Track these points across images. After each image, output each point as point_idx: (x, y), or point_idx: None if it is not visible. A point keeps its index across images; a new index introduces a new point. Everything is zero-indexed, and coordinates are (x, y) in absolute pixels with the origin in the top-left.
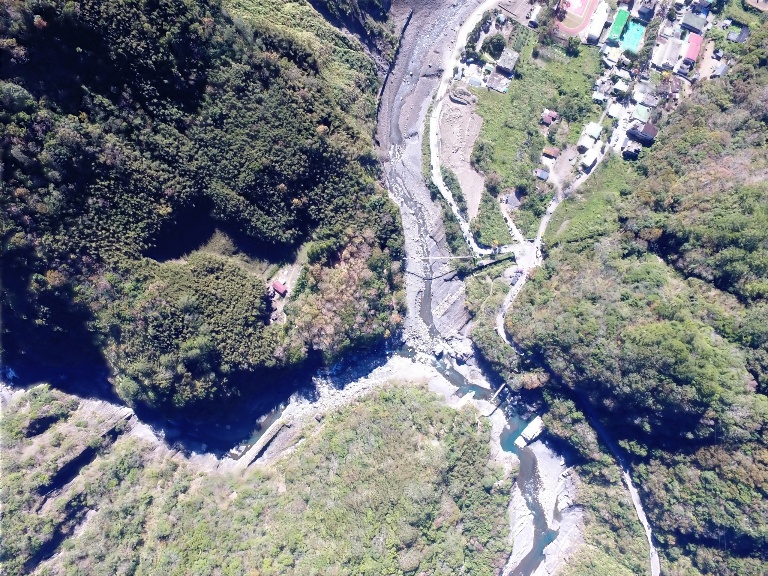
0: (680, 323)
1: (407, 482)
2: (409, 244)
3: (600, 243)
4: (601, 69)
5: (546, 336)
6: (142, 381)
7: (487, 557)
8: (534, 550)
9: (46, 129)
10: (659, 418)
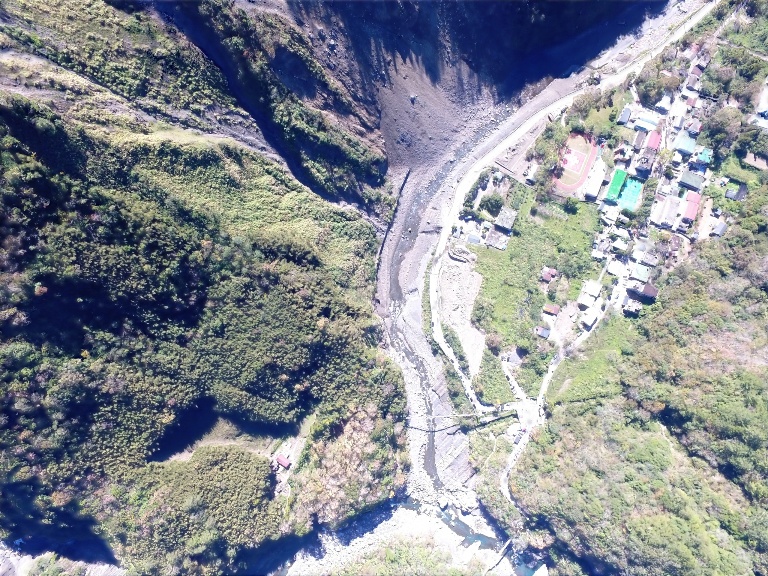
0: (685, 521)
1: None
2: (411, 399)
3: (603, 406)
4: (600, 227)
5: (551, 508)
6: None
7: None
8: None
9: (49, 376)
10: None
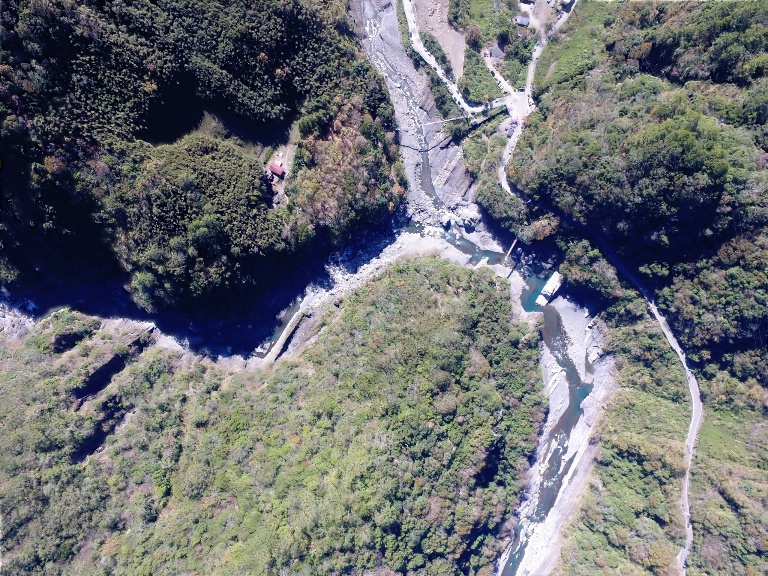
0: (682, 116)
1: (432, 332)
2: (400, 118)
3: (591, 76)
4: None
5: (550, 172)
6: (156, 272)
7: (525, 412)
8: (571, 406)
9: None
10: (675, 224)
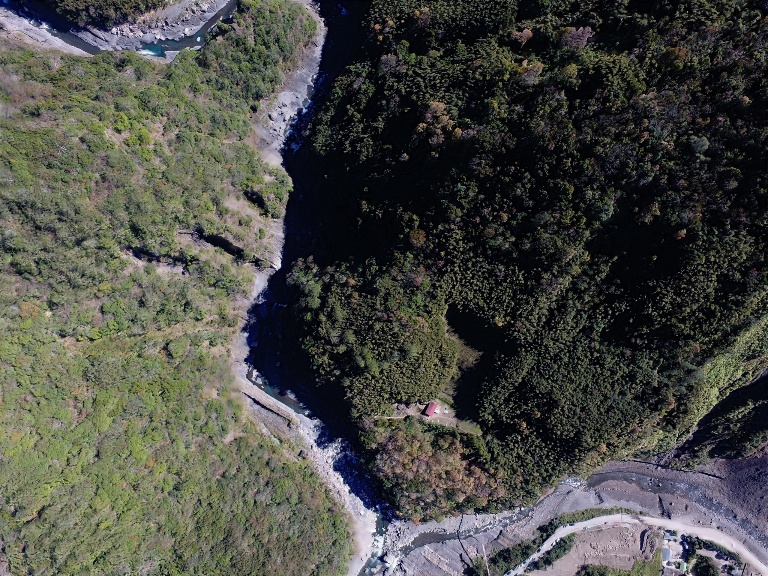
0: None
1: None
2: None
3: None
4: None
5: None
6: None
7: None
8: None
9: None
10: None
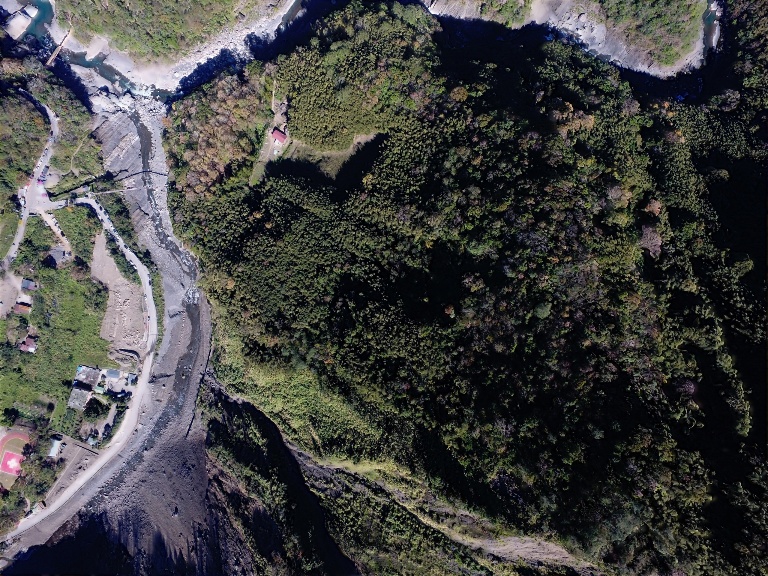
0: None
1: None
2: None
3: None
4: None
5: None
6: None
7: None
8: None
9: None
10: None
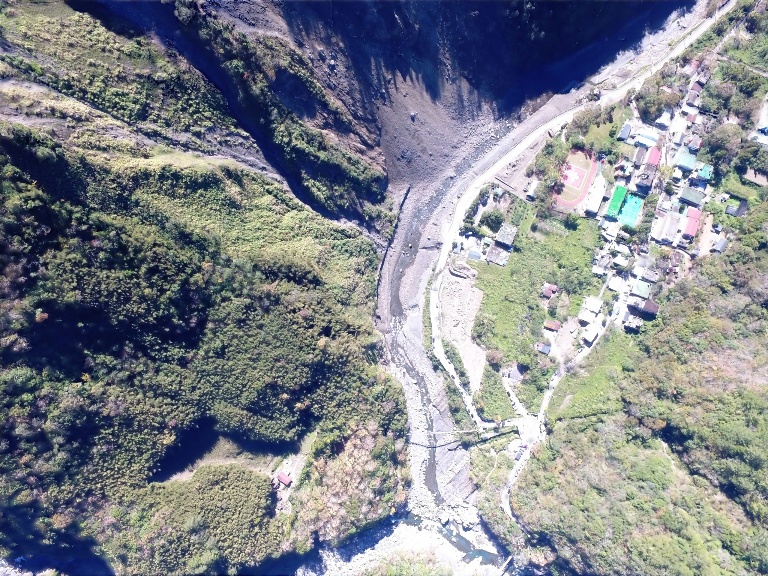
0: (687, 541)
1: None
2: (412, 414)
3: (604, 423)
4: (600, 243)
5: (552, 526)
6: None
7: None
8: None
9: (50, 400)
10: None
